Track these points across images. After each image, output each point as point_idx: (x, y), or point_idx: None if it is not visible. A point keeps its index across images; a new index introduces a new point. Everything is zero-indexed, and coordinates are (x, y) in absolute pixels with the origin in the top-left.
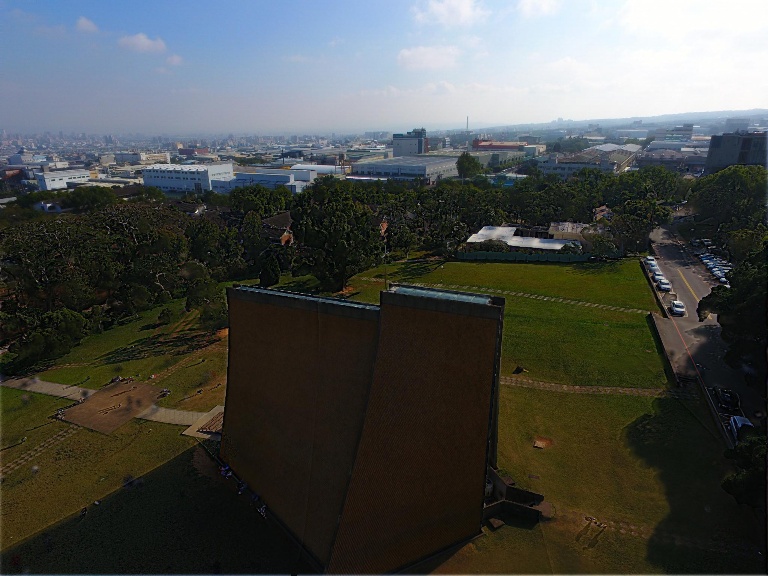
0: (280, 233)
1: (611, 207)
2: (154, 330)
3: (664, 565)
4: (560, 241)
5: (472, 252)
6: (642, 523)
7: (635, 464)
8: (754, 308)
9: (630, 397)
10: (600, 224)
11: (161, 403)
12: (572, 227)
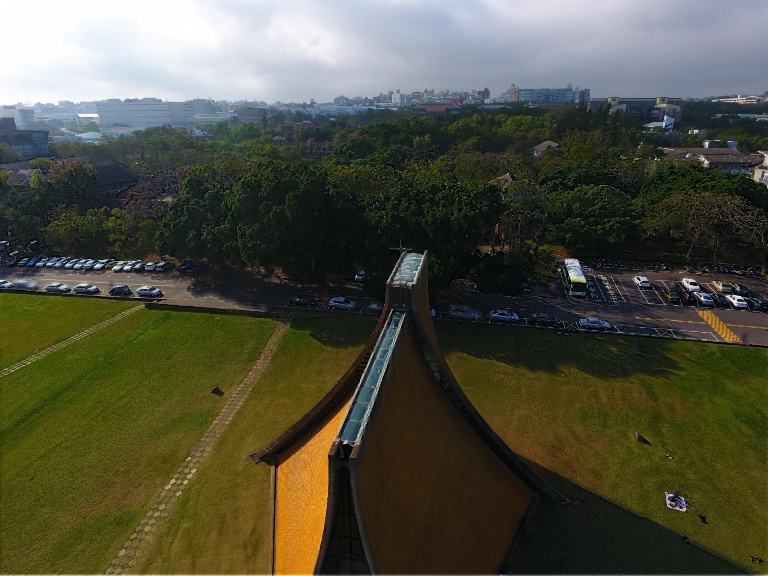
0: None
1: None
2: None
3: (445, 350)
4: None
5: None
6: None
7: None
8: None
9: (286, 337)
10: None
11: None
12: None
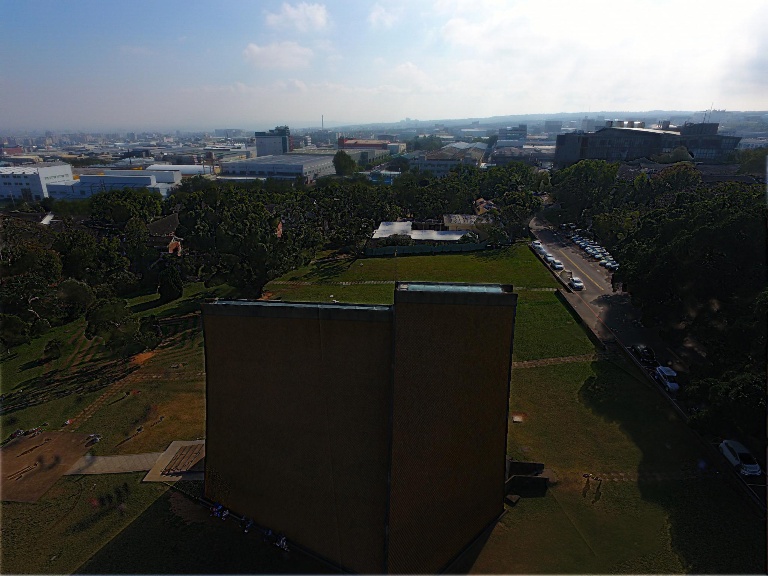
0: (166, 241)
1: (486, 199)
2: (42, 367)
3: (658, 500)
4: (455, 232)
5: (380, 248)
6: (627, 469)
7: (600, 421)
8: (658, 276)
9: (572, 364)
10: (491, 214)
11: (94, 451)
12: (463, 219)
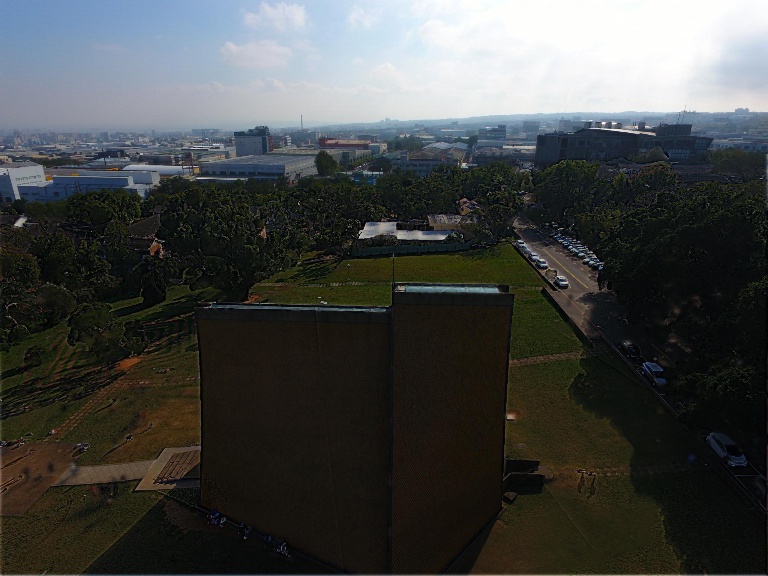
0: (147, 243)
1: (469, 199)
2: (22, 375)
3: (650, 493)
4: (440, 232)
5: (366, 248)
6: (619, 464)
7: (591, 417)
8: (643, 274)
9: (561, 362)
10: (475, 214)
11: (82, 461)
12: (447, 219)
